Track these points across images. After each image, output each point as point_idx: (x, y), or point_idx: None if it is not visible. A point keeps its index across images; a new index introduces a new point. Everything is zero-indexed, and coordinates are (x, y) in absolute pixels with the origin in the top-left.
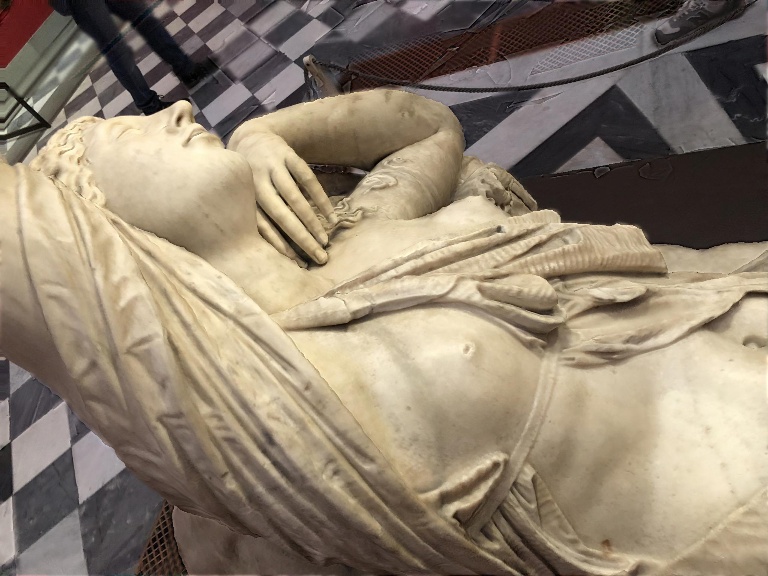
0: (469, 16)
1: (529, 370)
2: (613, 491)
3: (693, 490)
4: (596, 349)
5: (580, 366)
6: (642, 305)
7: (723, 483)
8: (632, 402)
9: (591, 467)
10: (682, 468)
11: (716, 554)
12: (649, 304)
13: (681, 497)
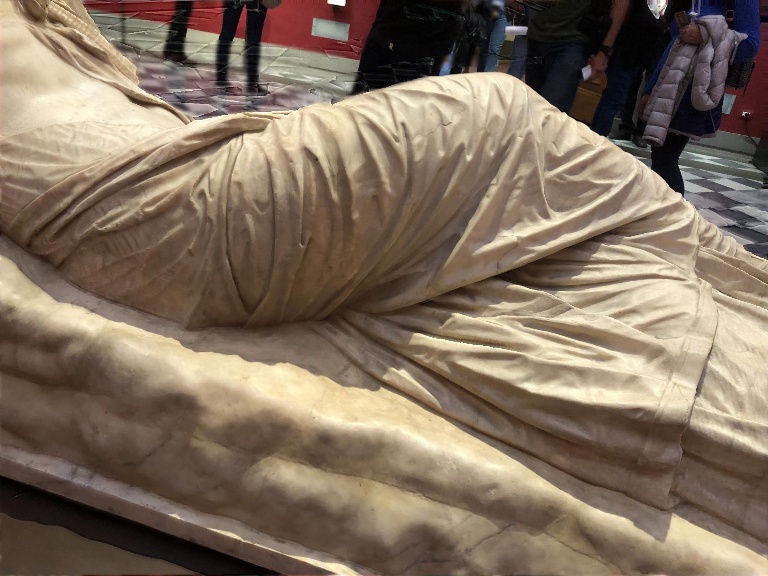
0: (190, 106)
1: (2, 4)
2: (6, 93)
3: (51, 112)
4: (51, 36)
5: (35, 35)
6: (99, 61)
7: (69, 116)
8: (53, 72)
9: (2, 73)
10: (54, 104)
11: (37, 135)
12: (104, 64)
13: (42, 112)
